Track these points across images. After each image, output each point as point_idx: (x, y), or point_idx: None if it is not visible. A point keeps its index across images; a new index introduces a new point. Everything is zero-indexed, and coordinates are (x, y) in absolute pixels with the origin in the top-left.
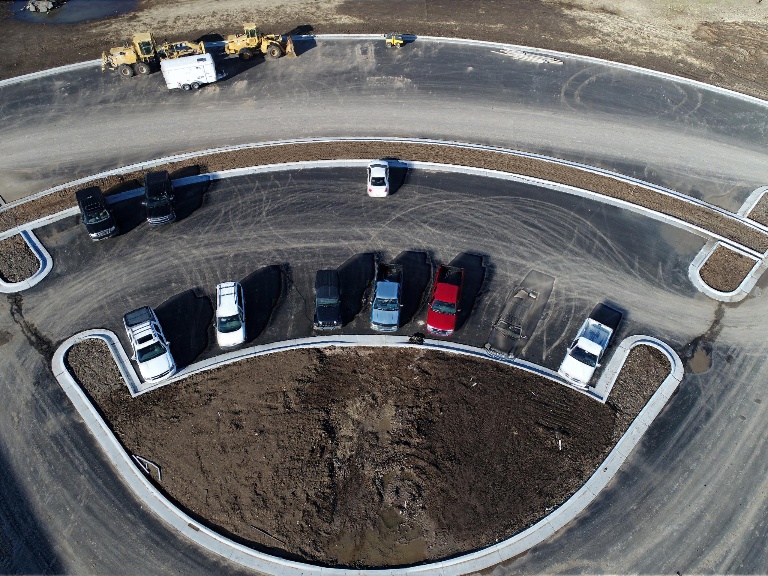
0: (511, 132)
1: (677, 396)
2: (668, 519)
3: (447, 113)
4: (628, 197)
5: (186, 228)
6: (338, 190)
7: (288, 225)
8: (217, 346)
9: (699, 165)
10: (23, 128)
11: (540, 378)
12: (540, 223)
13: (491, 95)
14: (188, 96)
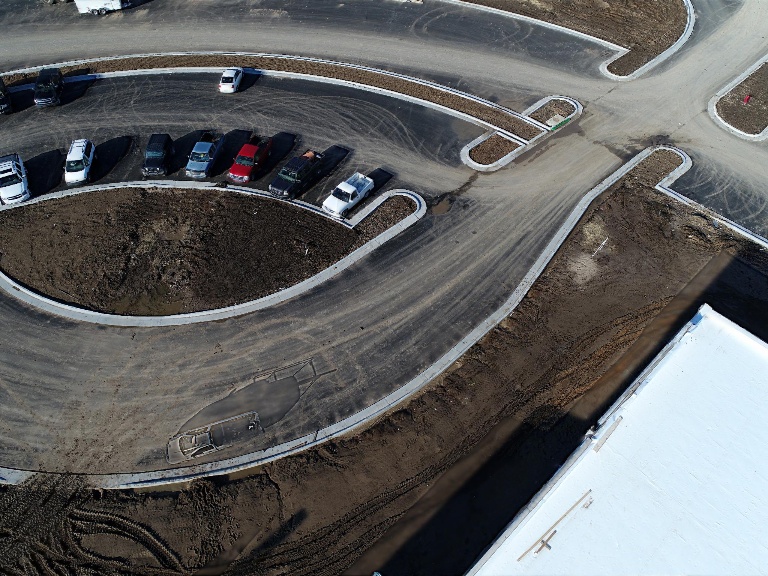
0: (358, 52)
1: (413, 228)
2: (369, 298)
3: (309, 37)
4: (436, 100)
5: (67, 110)
6: (198, 88)
7: (149, 110)
8: (66, 184)
9: (506, 79)
10: None
11: (308, 212)
12: (354, 115)
13: (352, 25)
14: (96, 19)
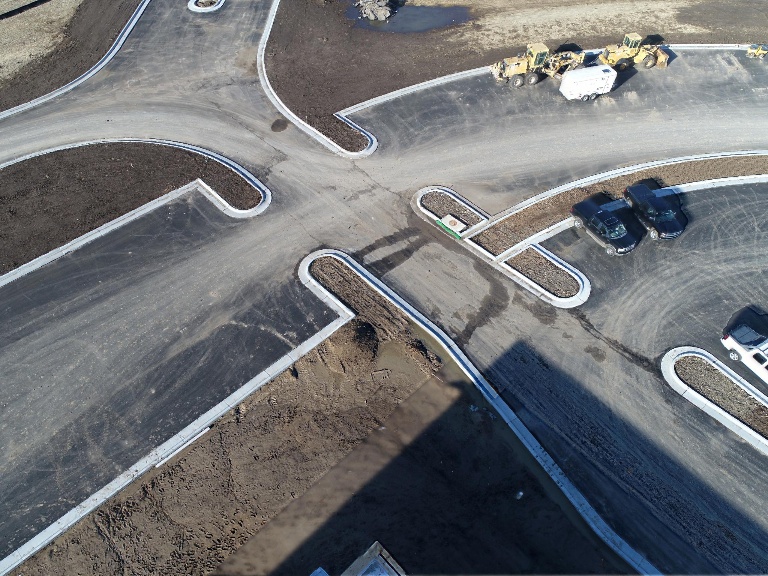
0: None
1: None
2: None
3: None
4: None
5: (692, 243)
6: None
7: None
8: None
9: None
10: (451, 139)
11: None
12: None
13: None
14: (589, 107)
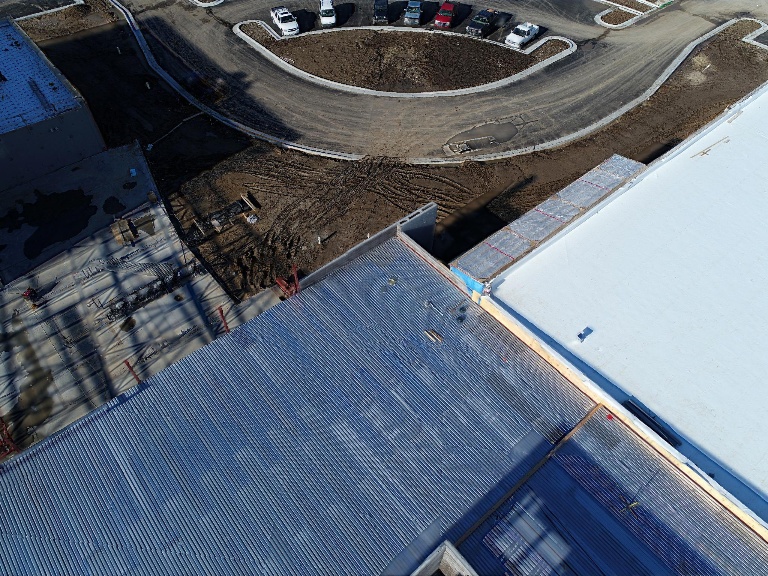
0: None
1: (570, 56)
2: (549, 89)
3: None
4: None
5: None
6: None
7: None
8: (320, 27)
9: None
10: None
11: (495, 45)
12: None
13: None
14: None
